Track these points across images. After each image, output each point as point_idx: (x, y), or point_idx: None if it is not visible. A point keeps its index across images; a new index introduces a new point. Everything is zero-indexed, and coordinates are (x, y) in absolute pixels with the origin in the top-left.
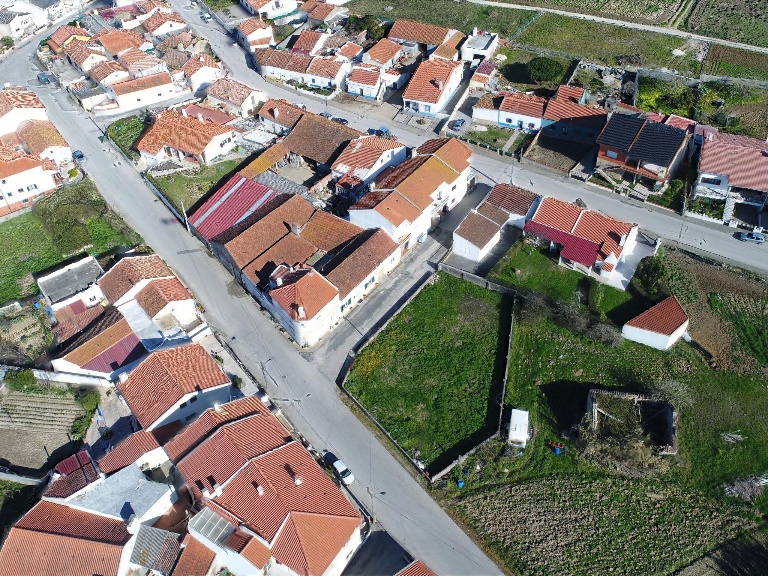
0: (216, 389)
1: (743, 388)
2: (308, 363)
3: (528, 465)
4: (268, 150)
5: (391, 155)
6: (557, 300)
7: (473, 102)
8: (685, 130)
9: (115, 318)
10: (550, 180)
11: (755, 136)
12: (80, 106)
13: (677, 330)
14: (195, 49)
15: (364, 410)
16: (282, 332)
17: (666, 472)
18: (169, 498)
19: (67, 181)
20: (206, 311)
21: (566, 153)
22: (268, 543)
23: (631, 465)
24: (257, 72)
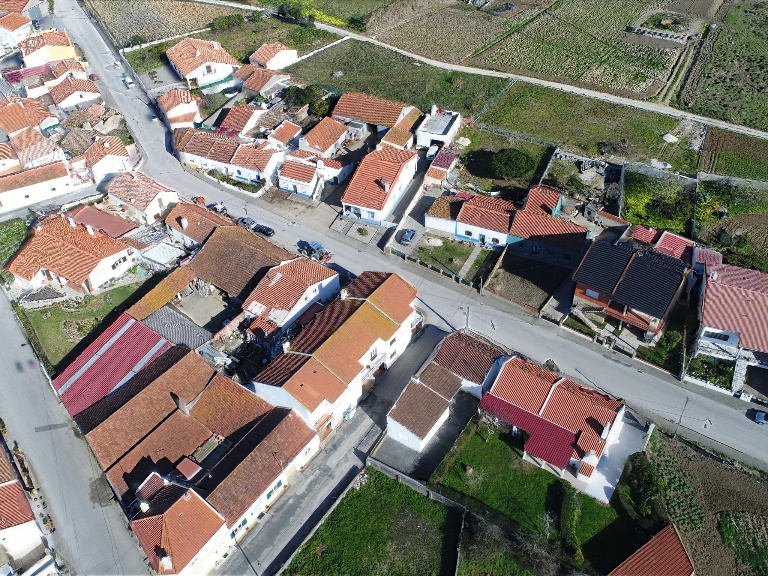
0: None
1: None
2: None
3: None
4: (169, 276)
5: (318, 289)
6: (518, 525)
7: (427, 204)
8: (682, 255)
9: None
10: (516, 321)
11: (767, 261)
12: None
13: None
14: (106, 126)
15: None
16: (151, 569)
17: None
18: None
19: None
20: (56, 529)
21: (536, 281)
22: None
23: None
24: (176, 157)
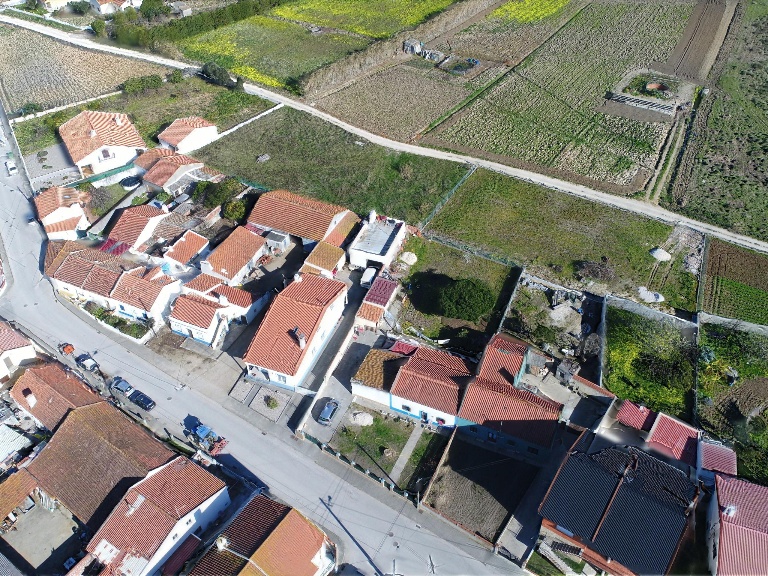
0: None
1: None
2: None
3: None
4: None
5: (194, 517)
6: None
7: (357, 355)
8: None
9: None
10: (463, 558)
11: None
12: None
13: None
14: None
15: None
16: None
17: None
18: None
19: None
20: None
21: (492, 488)
22: None
23: None
24: (48, 280)
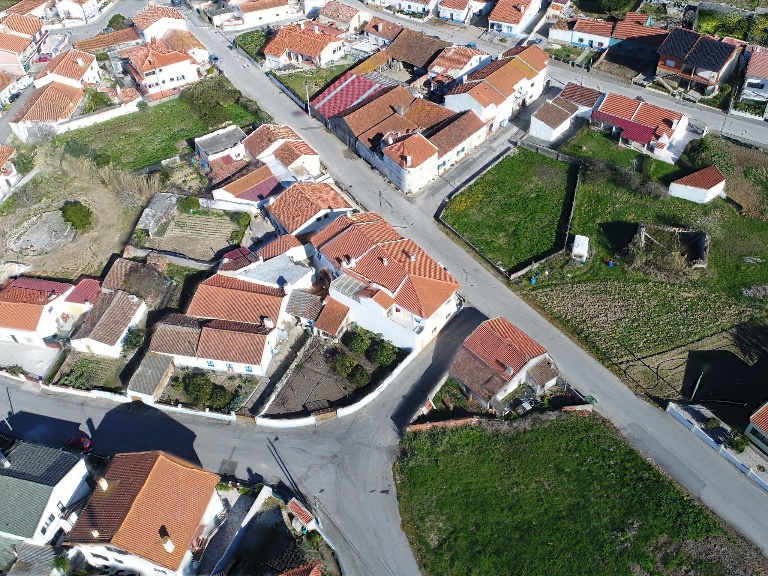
0: (343, 211)
1: (766, 229)
2: (411, 204)
3: (587, 272)
4: (374, 56)
5: (479, 60)
6: None
7: (549, 27)
8: None
9: (259, 165)
10: (615, 86)
11: None
12: (210, 23)
13: (715, 186)
14: None
15: (457, 233)
16: (389, 184)
17: (697, 280)
18: (310, 278)
19: (206, 77)
20: (327, 168)
21: (630, 66)
22: (392, 293)
23: (669, 274)
24: (359, 0)
